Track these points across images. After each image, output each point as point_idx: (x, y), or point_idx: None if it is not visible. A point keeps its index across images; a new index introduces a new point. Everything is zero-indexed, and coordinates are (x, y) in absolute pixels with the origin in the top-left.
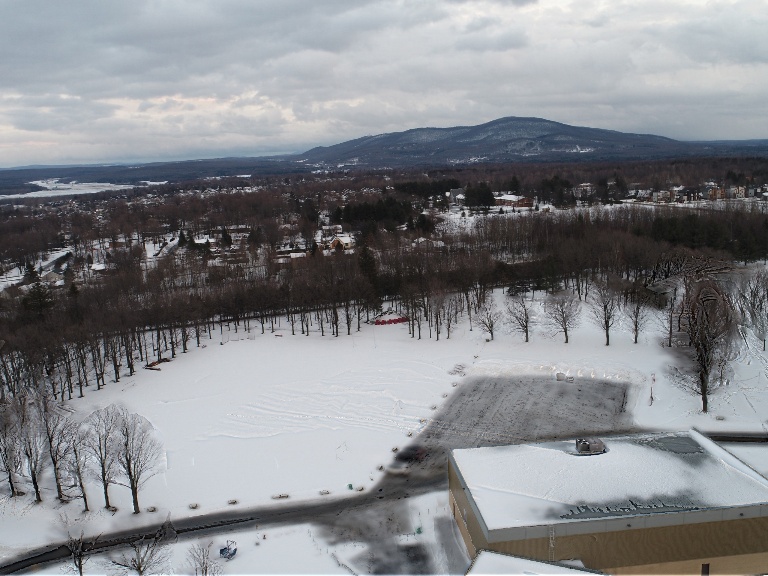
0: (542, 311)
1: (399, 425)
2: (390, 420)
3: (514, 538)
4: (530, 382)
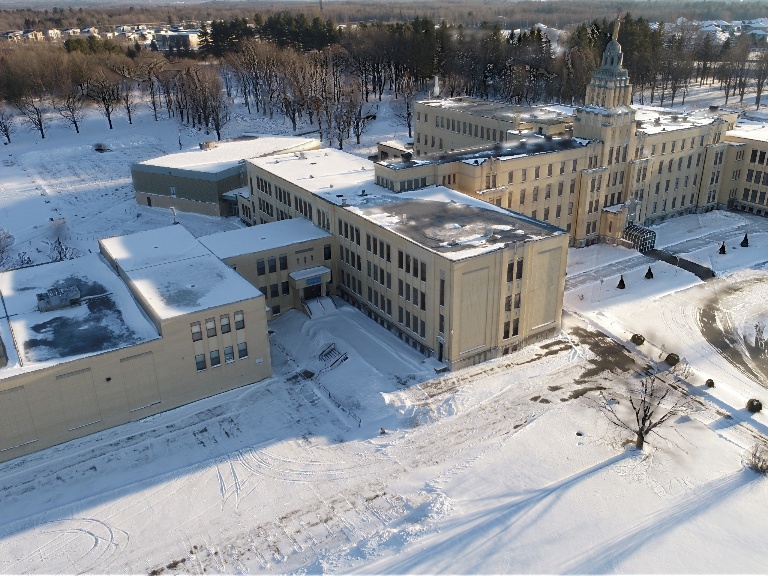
0: (52, 108)
1: (22, 194)
2: (8, 195)
3: (226, 176)
4: (82, 157)
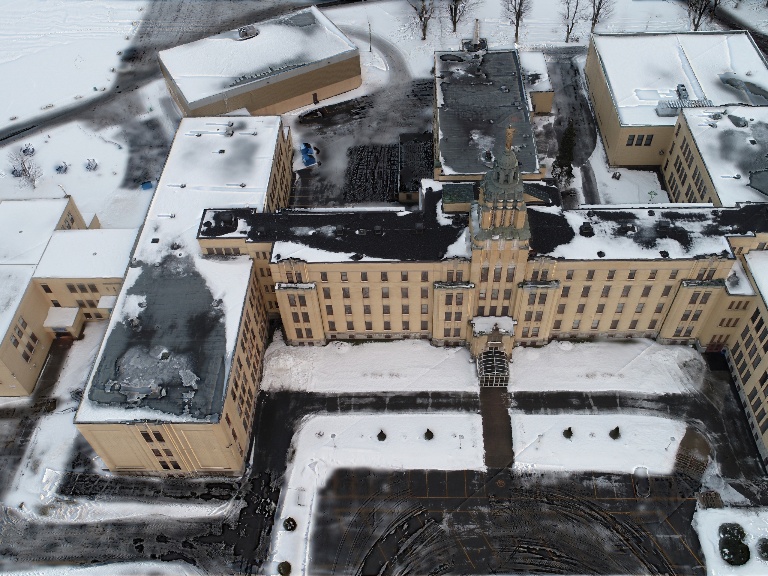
0: None
1: (117, 30)
2: (108, 27)
3: (205, 104)
4: None
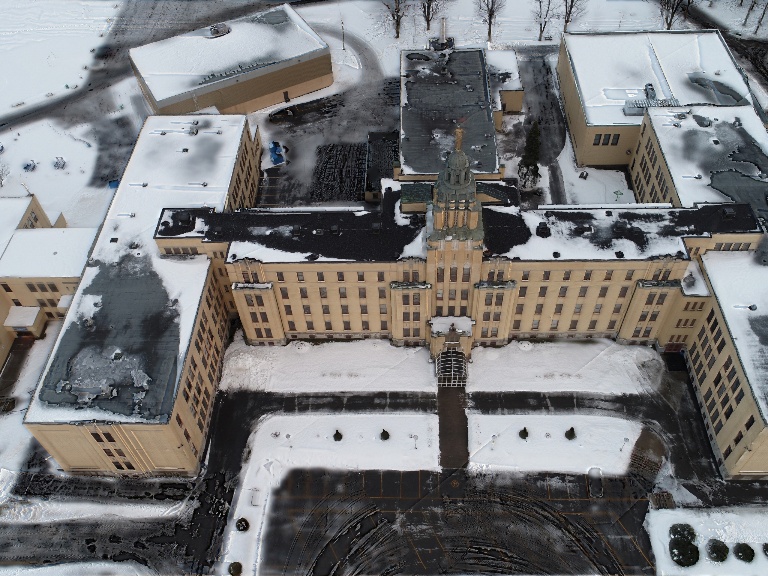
0: None
1: (91, 28)
2: (83, 24)
3: (173, 103)
4: None
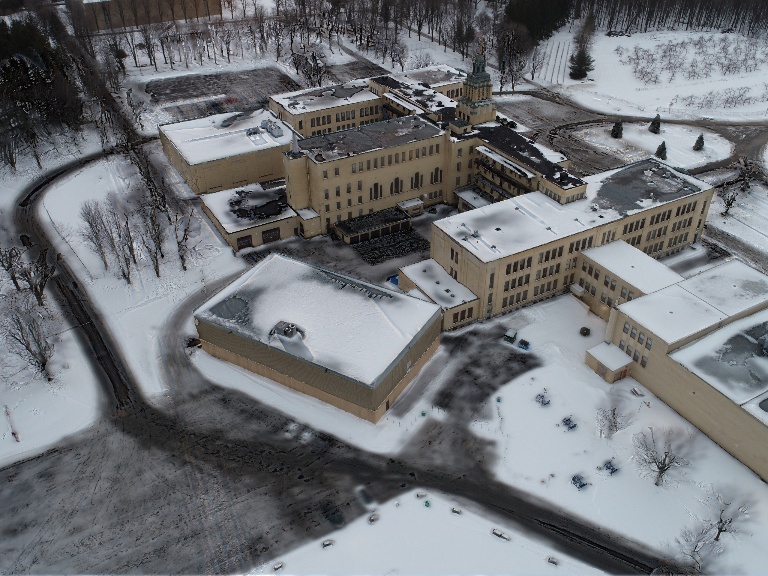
0: None
1: None
2: None
3: None
4: None
